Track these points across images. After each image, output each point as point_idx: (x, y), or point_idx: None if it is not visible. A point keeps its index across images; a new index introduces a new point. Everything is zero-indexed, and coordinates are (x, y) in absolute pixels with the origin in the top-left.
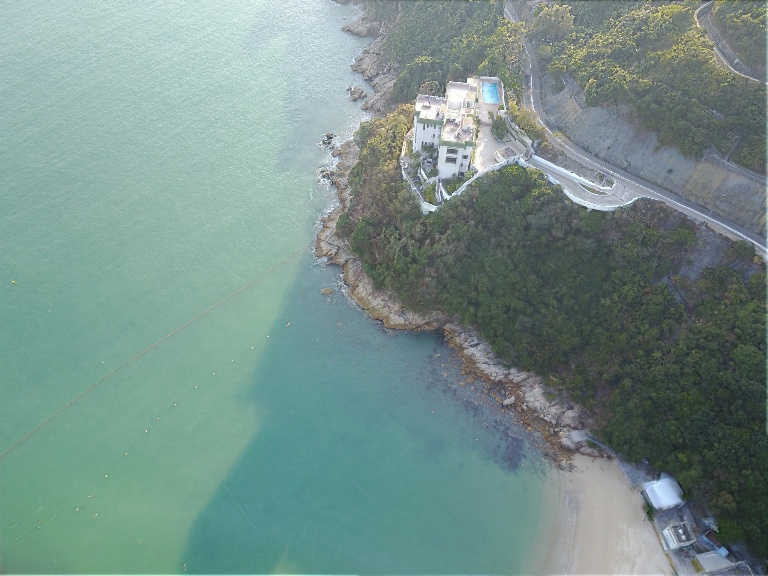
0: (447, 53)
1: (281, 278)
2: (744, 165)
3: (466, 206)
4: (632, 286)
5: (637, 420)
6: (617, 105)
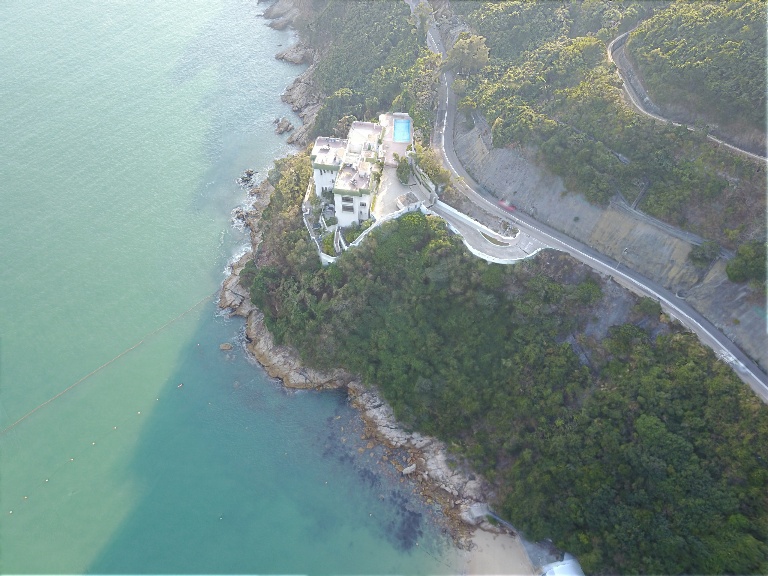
0: (369, 85)
1: (179, 332)
2: (651, 214)
3: (364, 257)
4: (534, 346)
5: (537, 495)
6: (523, 147)
